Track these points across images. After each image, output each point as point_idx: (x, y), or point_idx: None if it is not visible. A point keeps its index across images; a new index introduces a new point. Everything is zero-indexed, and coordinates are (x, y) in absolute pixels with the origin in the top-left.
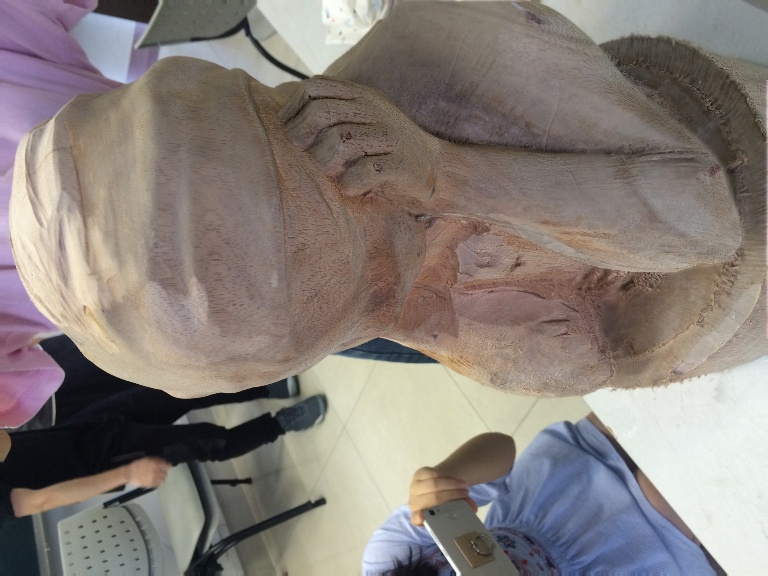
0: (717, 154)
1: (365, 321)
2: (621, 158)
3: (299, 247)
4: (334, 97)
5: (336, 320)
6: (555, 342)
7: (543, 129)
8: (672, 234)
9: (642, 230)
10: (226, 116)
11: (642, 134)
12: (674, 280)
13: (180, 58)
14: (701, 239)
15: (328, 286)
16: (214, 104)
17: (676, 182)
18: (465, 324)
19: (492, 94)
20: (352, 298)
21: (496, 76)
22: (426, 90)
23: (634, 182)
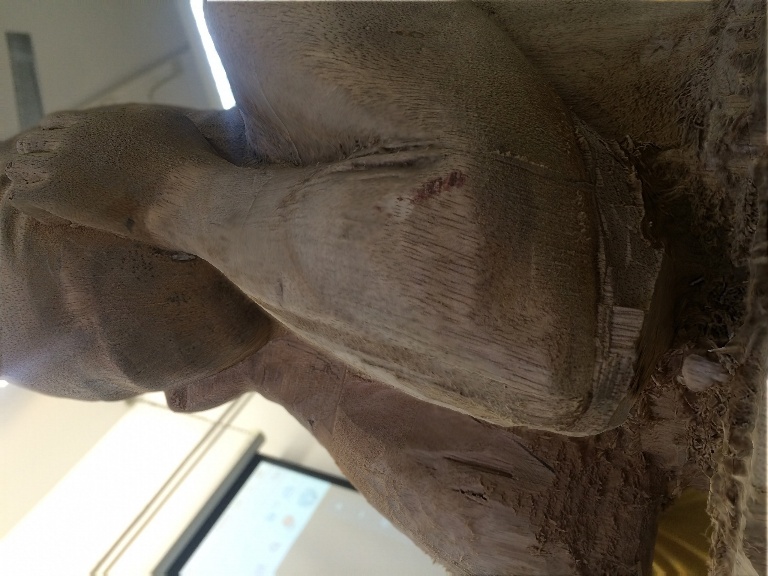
0: None
1: (88, 359)
2: (317, 171)
3: None
4: (57, 127)
5: (30, 346)
6: (452, 500)
7: (287, 133)
8: (348, 325)
9: (297, 306)
10: None
11: (347, 122)
12: None
13: None
14: (413, 349)
15: (3, 309)
16: None
17: (338, 215)
18: (340, 419)
19: None
20: (41, 328)
21: None
22: None
23: (290, 214)
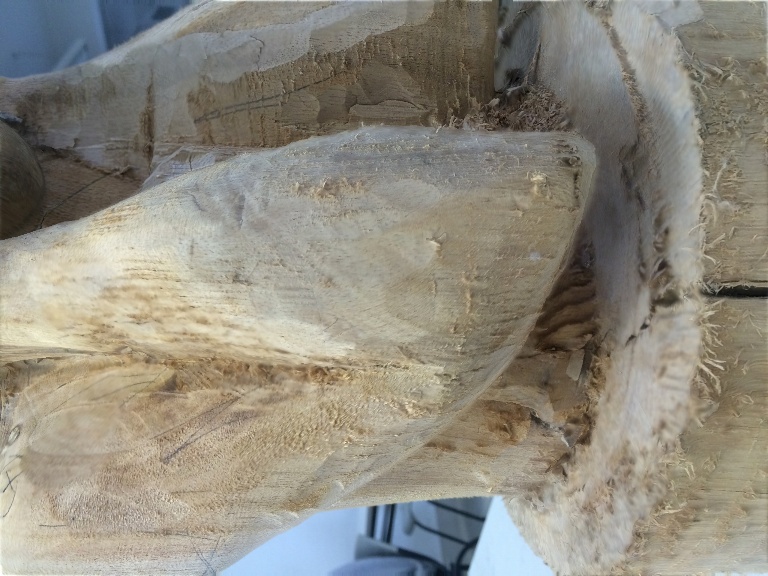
0: (502, 69)
1: None
2: None
3: None
4: None
5: None
6: None
7: None
8: None
9: None
10: None
11: None
12: (566, 84)
13: None
14: None
15: None
16: None
17: None
18: None
19: None
20: None
21: None
22: None
23: None
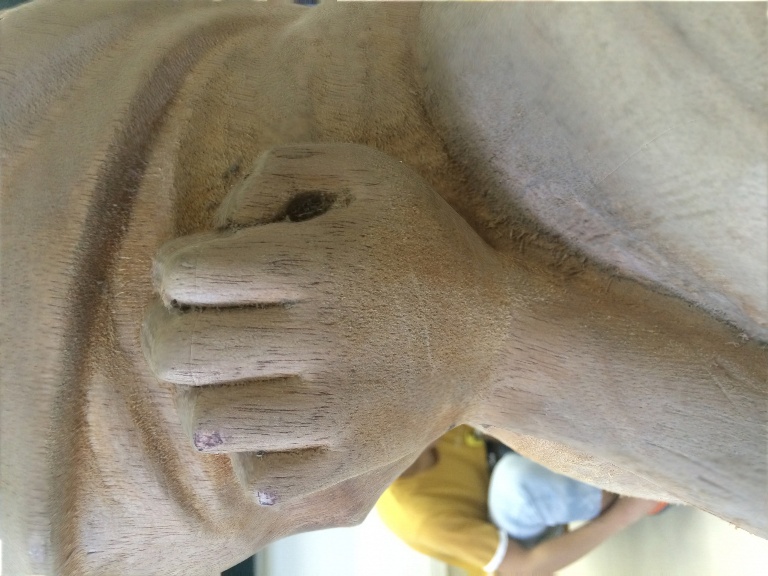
0: None
1: None
2: None
3: (111, 559)
4: (235, 303)
5: None
6: None
7: None
8: None
9: None
10: (6, 302)
11: None
12: None
13: (5, 57)
14: None
15: (182, 575)
16: (3, 250)
17: None
18: None
19: (685, 248)
20: (245, 556)
21: (705, 233)
22: (553, 168)
23: None
